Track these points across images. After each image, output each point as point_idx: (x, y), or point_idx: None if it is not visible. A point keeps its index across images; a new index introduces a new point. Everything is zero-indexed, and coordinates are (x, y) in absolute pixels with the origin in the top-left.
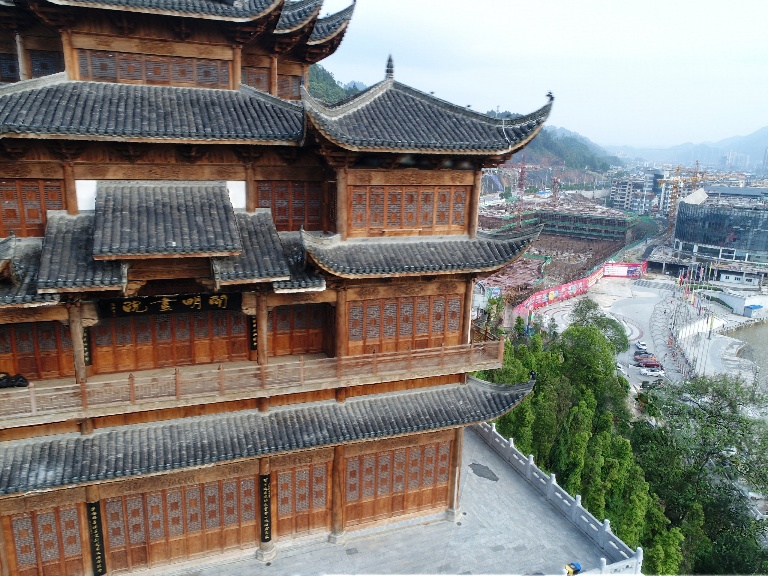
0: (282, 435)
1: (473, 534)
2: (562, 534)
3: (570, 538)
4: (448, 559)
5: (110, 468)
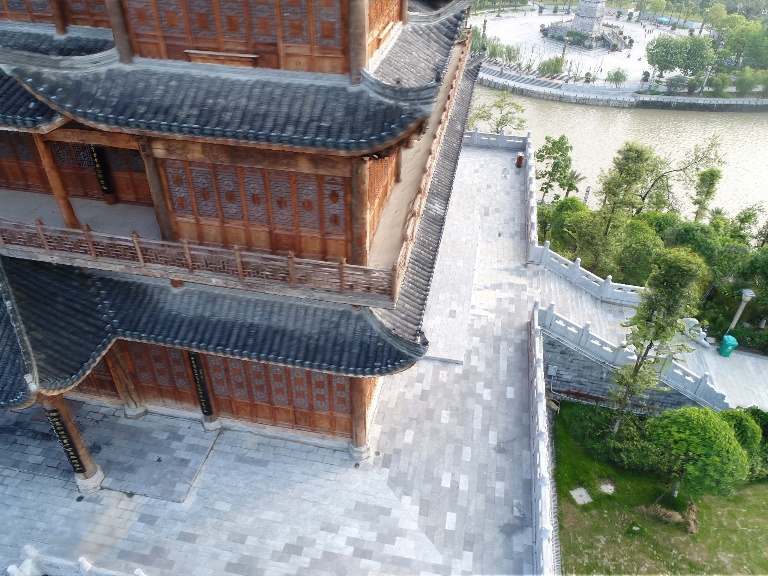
0: (452, 132)
1: (459, 172)
2: (481, 152)
3: (486, 151)
4: (473, 186)
5: (445, 187)
